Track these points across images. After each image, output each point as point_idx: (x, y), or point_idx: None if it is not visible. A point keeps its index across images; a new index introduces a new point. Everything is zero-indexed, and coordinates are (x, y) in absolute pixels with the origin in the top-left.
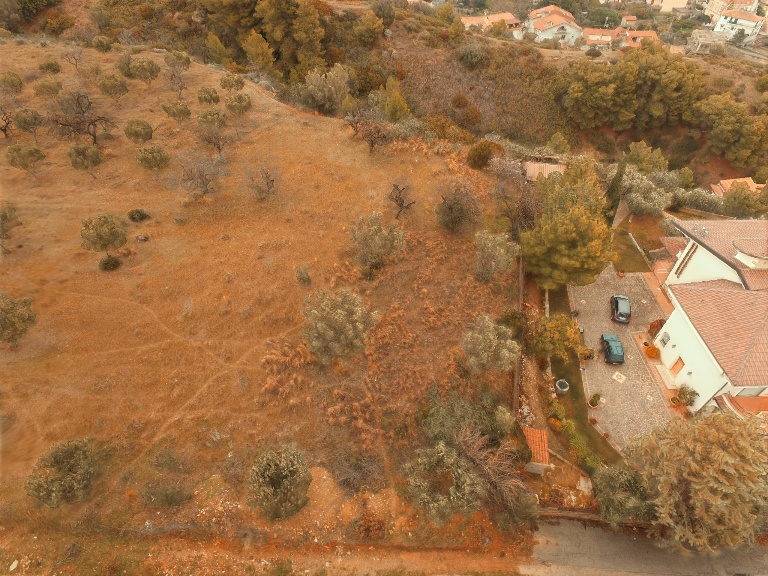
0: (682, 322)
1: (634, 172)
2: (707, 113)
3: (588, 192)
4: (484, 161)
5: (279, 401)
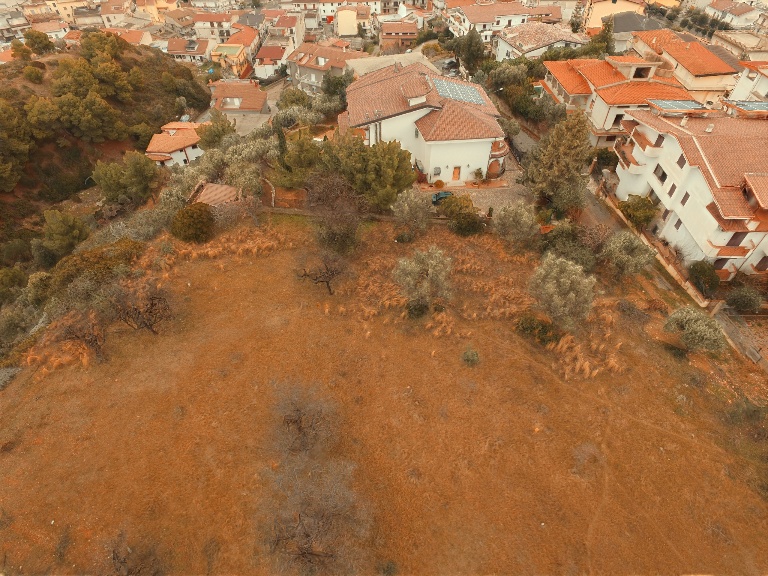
0: (443, 151)
1: None
2: (54, 119)
3: (351, 139)
4: (211, 224)
5: (620, 359)
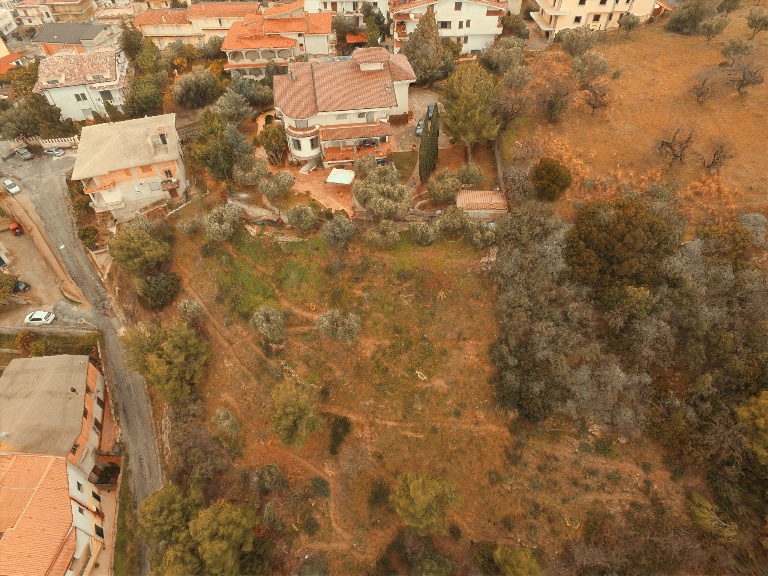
0: None
1: (372, 229)
2: None
3: None
4: None
5: None
